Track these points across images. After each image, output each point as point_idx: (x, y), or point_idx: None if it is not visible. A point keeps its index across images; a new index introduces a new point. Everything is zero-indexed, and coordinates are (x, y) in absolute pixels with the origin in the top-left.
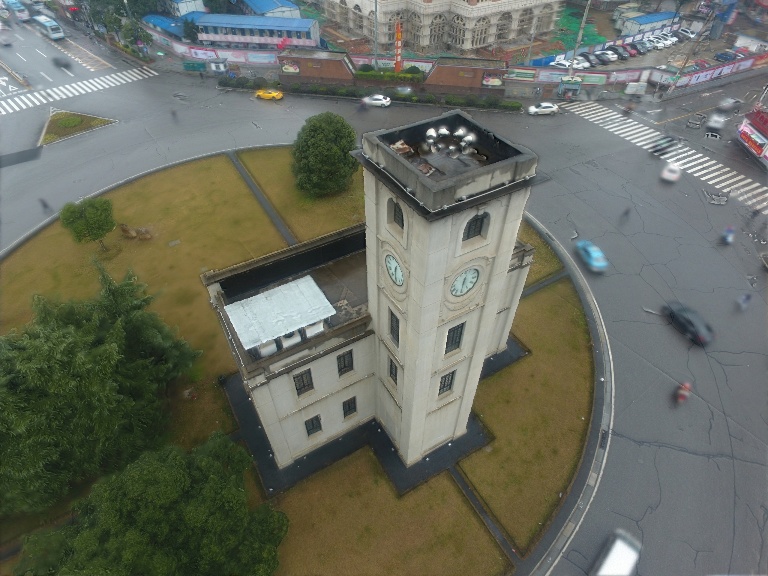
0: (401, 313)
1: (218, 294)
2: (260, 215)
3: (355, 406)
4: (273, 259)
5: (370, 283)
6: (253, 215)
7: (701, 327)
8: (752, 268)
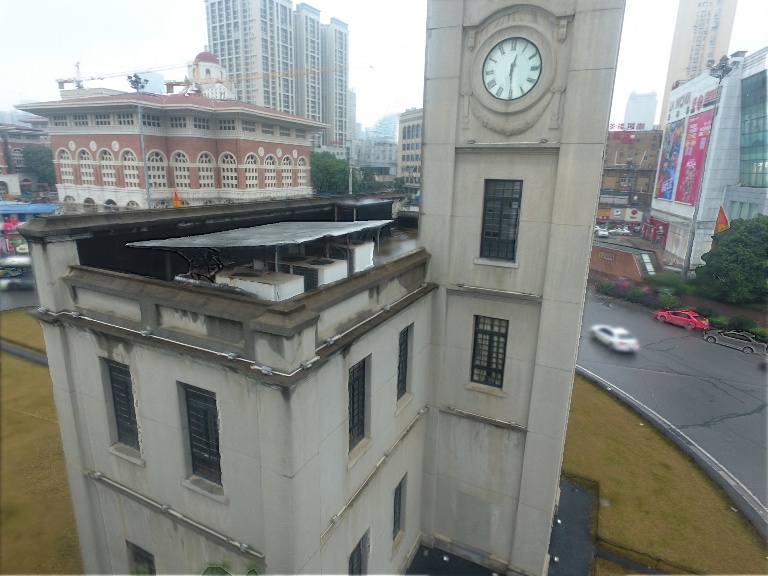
0: (539, 145)
1: (76, 266)
2: (26, 369)
3: (399, 513)
4: (193, 214)
5: (432, 164)
6: (11, 371)
7: (617, 334)
8: (594, 300)
